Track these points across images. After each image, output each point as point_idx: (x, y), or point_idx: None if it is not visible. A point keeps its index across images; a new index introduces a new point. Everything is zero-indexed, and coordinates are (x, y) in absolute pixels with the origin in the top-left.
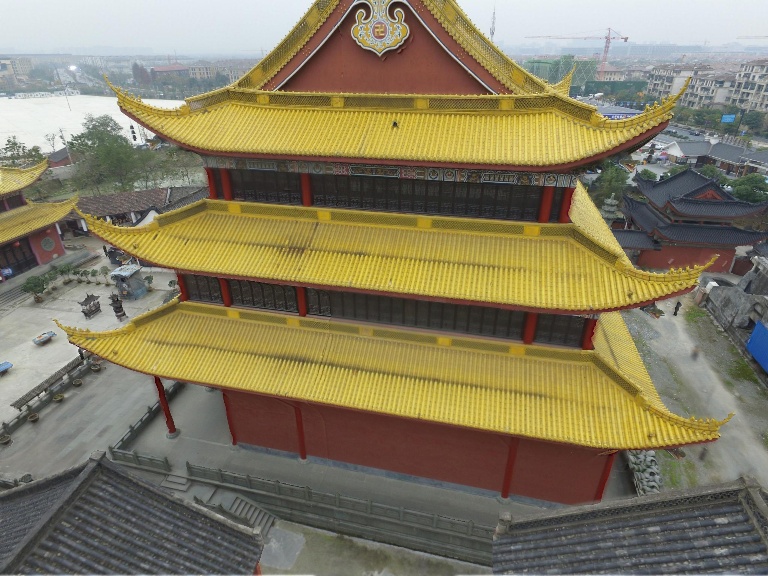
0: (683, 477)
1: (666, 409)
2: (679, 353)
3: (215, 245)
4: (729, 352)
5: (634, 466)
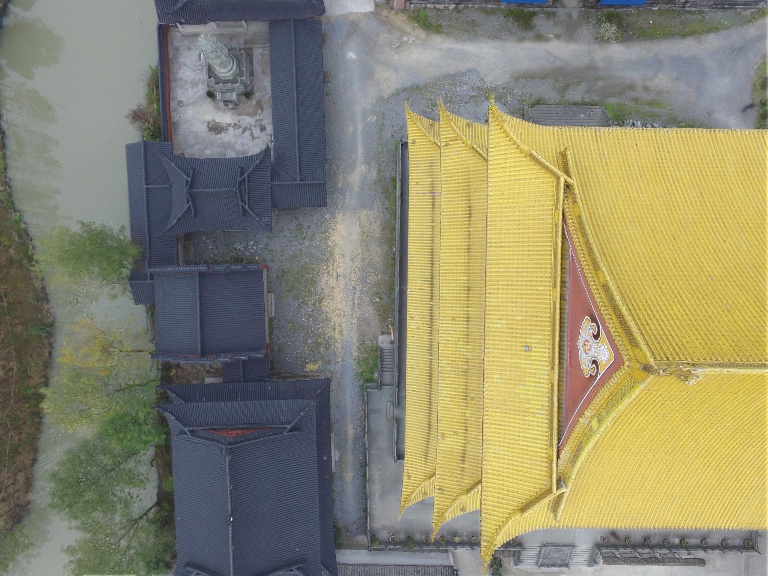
0: (646, 108)
1: None
2: (502, 62)
3: None
4: (491, 16)
5: None
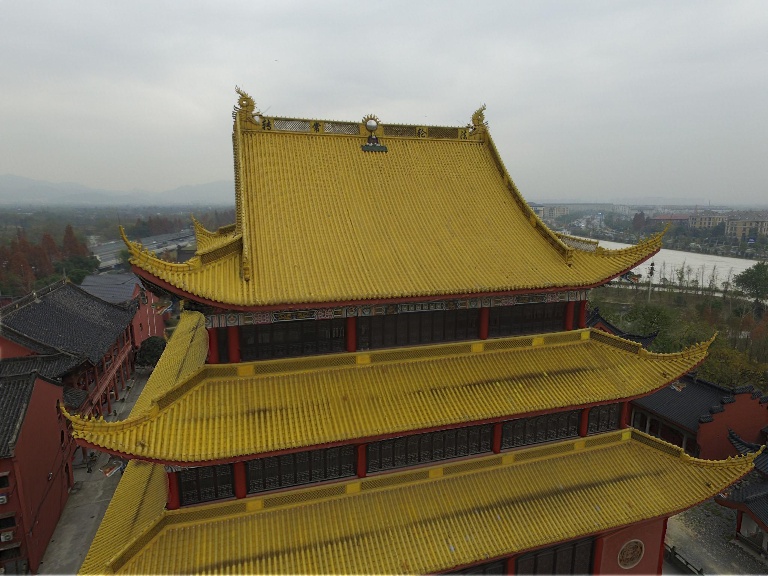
0: None
1: None
2: None
3: (198, 314)
4: None
5: None
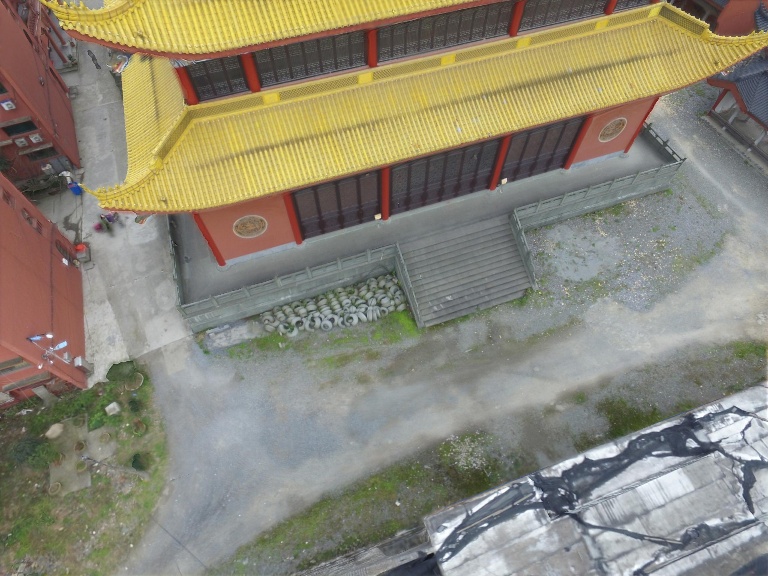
0: (350, 349)
1: (198, 204)
2: (610, 336)
3: None
4: (678, 401)
5: (336, 305)
